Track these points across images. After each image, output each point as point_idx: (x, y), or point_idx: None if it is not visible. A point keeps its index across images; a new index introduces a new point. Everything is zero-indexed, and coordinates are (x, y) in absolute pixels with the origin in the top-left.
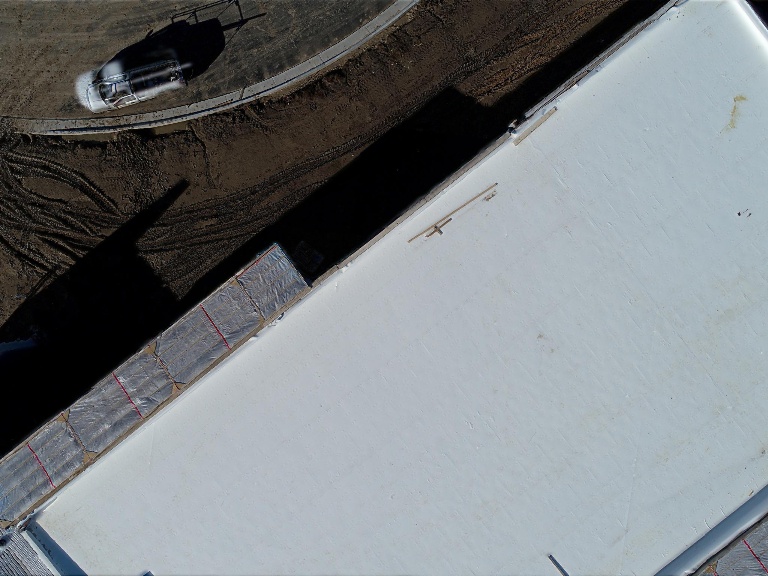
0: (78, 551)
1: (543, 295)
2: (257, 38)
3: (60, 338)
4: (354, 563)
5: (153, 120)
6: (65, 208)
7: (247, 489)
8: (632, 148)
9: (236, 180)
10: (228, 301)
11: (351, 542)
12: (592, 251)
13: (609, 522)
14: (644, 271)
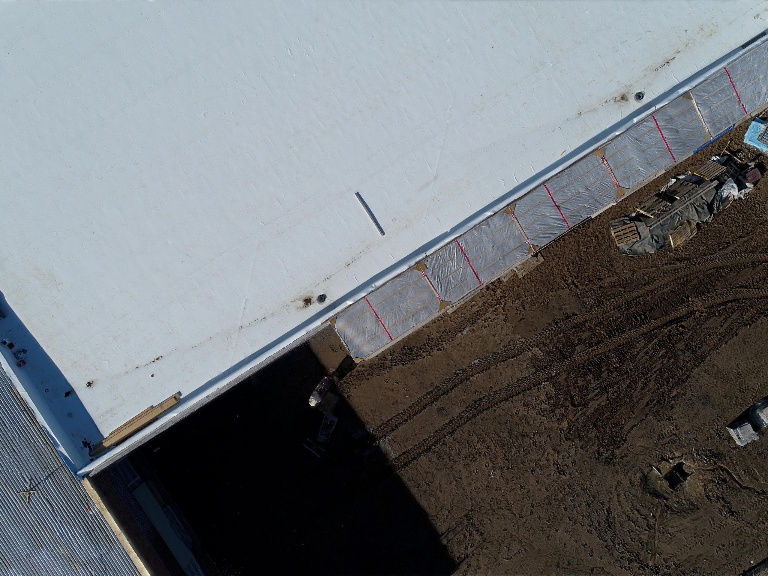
0: None
1: None
2: None
3: None
4: (161, 177)
5: None
6: None
7: (61, 89)
8: None
9: None
10: None
11: (160, 155)
12: None
13: (419, 166)
14: None
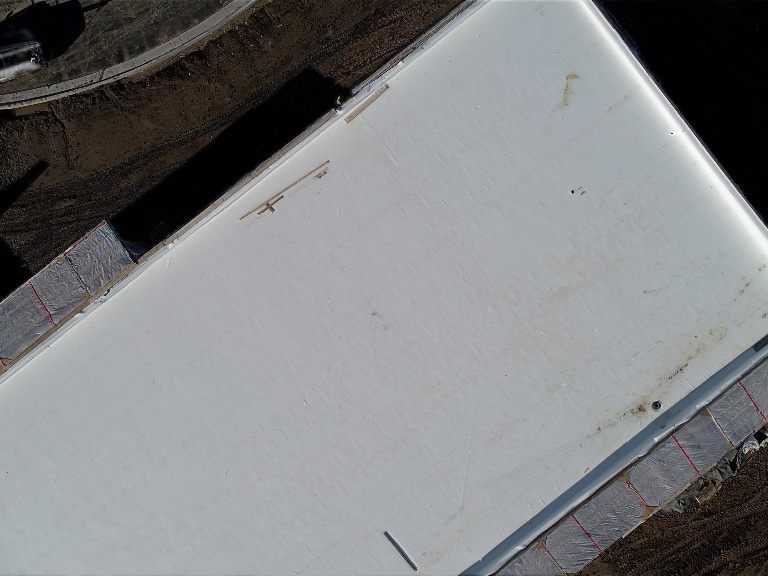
0: None
1: (376, 272)
2: (117, 19)
3: None
4: (189, 539)
5: (13, 101)
6: None
7: (80, 465)
8: (464, 126)
9: (95, 161)
10: (56, 277)
11: (186, 518)
12: (425, 229)
13: (444, 499)
14: (477, 249)
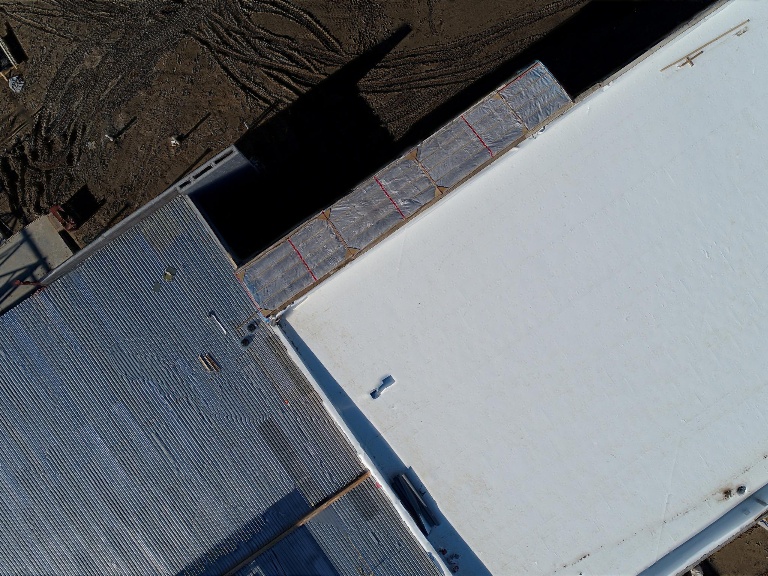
0: (324, 351)
1: None
2: None
3: (279, 170)
4: (586, 381)
5: None
6: (291, 44)
7: (489, 301)
8: None
9: (458, 28)
10: (490, 113)
11: (585, 360)
12: None
13: None
14: None
